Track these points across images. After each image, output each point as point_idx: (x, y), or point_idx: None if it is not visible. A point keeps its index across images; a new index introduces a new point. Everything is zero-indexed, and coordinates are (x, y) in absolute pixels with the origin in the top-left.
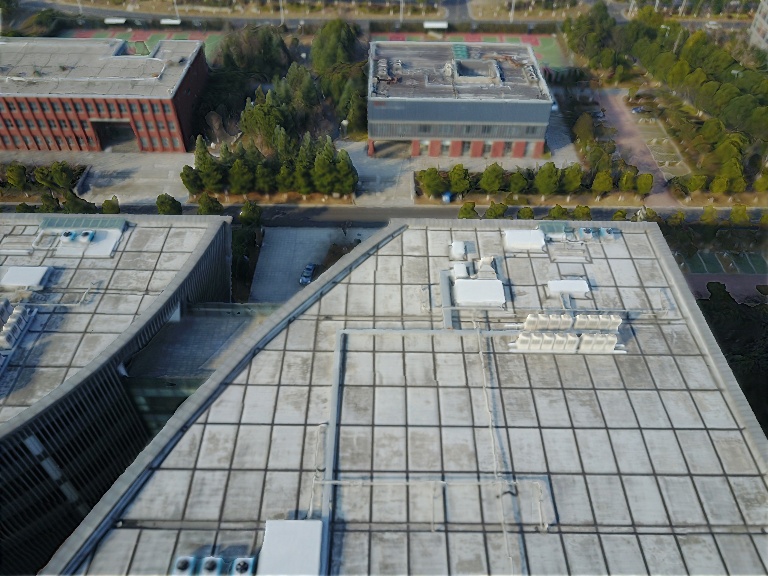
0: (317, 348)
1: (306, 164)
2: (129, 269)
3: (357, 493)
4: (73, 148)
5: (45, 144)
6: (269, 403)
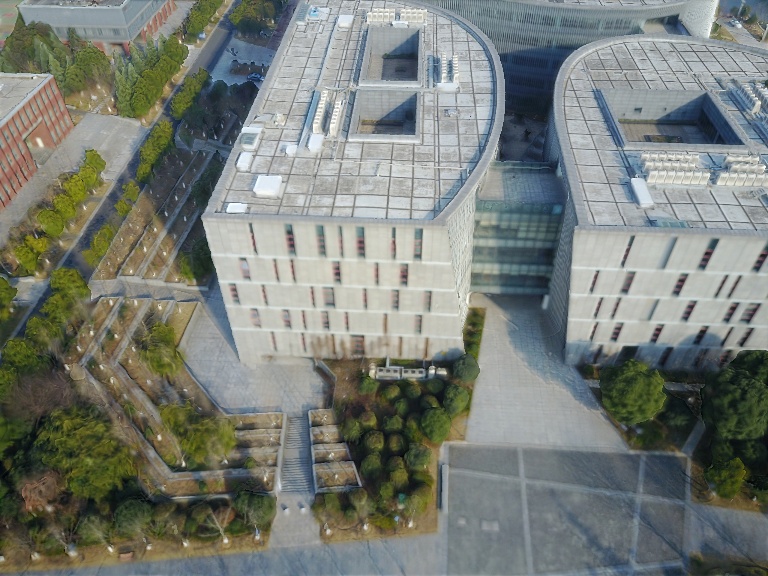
0: None
1: (155, 58)
2: (341, 5)
3: None
4: (21, 184)
5: (6, 196)
6: None
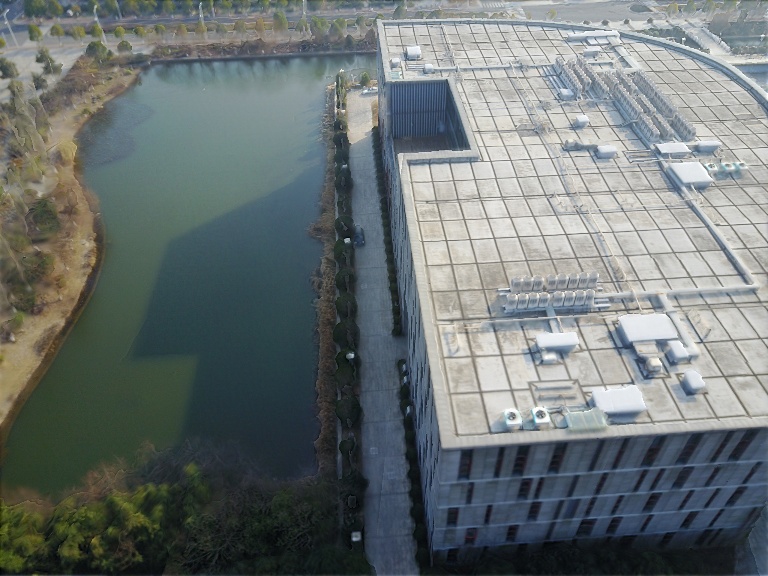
0: (766, 275)
1: None
2: None
3: (671, 201)
4: None
5: None
6: (767, 235)
